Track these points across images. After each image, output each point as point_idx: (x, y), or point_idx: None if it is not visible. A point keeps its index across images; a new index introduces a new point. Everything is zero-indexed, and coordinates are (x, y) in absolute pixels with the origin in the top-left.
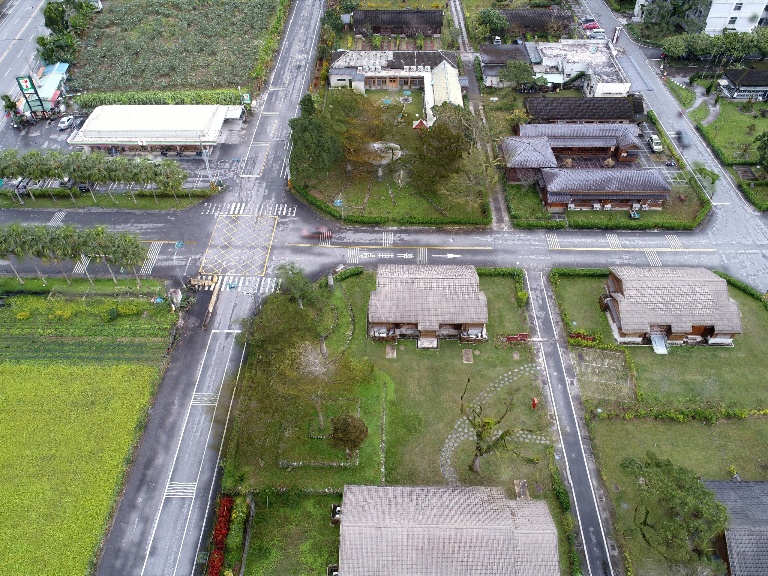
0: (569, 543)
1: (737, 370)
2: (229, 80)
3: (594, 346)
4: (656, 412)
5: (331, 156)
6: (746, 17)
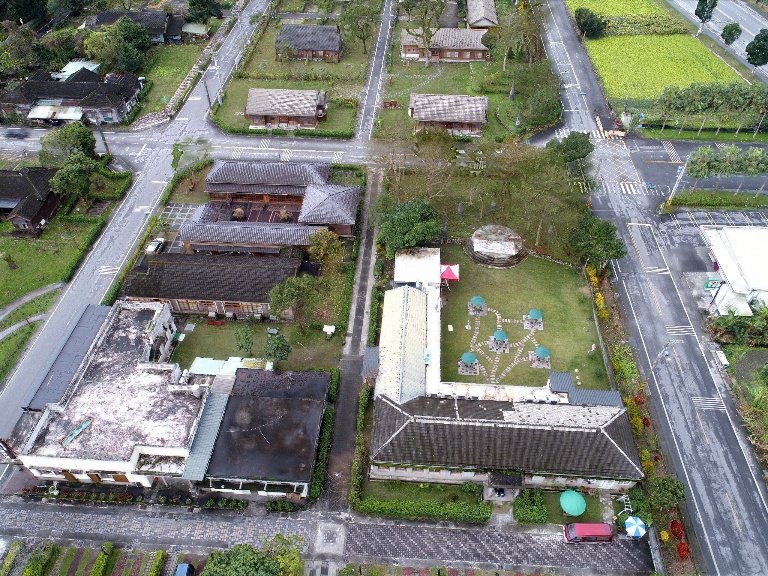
0: None
1: None
2: None
3: None
4: None
5: None
6: None
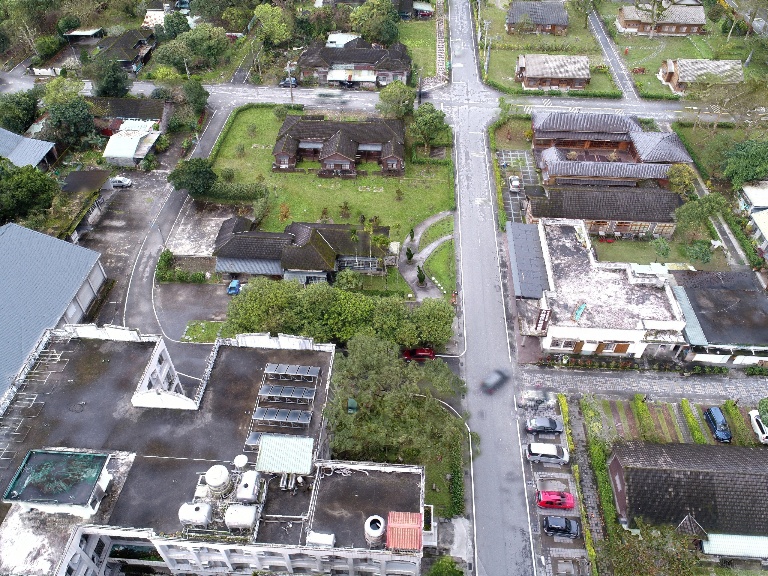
0: None
1: None
2: None
3: None
4: (569, 45)
5: None
6: None
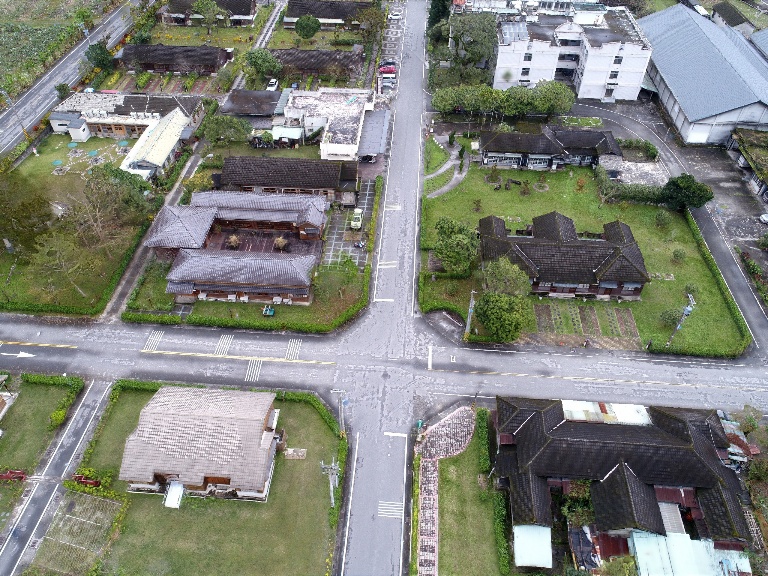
0: None
1: (246, 538)
2: None
3: (92, 493)
4: None
5: None
6: (540, 68)
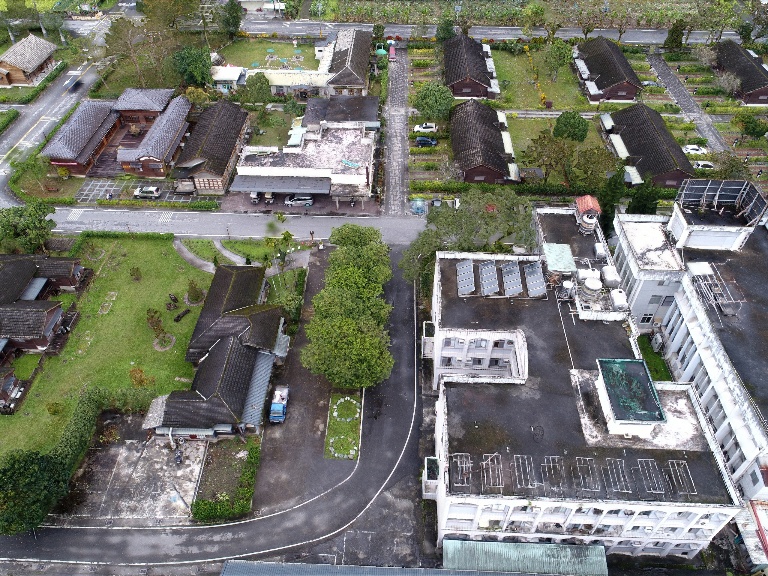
0: None
1: None
2: (344, 8)
3: None
4: None
5: None
6: None
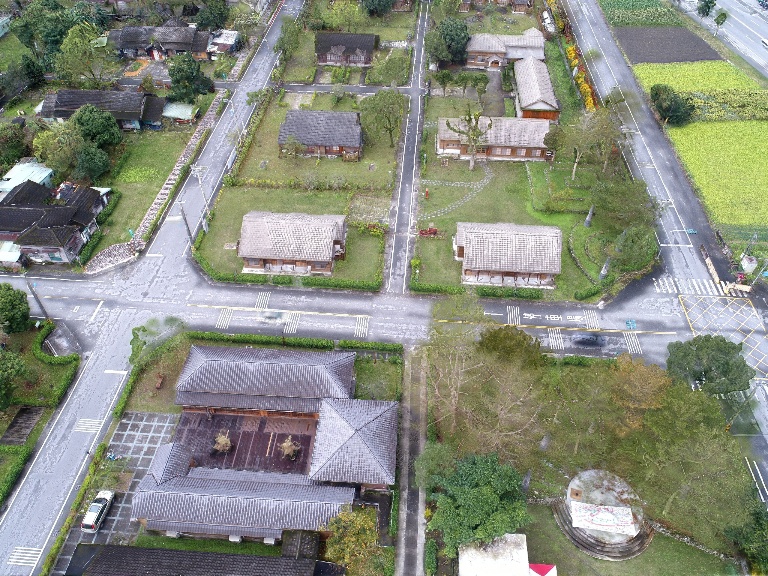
0: (425, 142)
1: (267, 209)
2: None
3: None
4: (348, 182)
5: (670, 359)
6: None
